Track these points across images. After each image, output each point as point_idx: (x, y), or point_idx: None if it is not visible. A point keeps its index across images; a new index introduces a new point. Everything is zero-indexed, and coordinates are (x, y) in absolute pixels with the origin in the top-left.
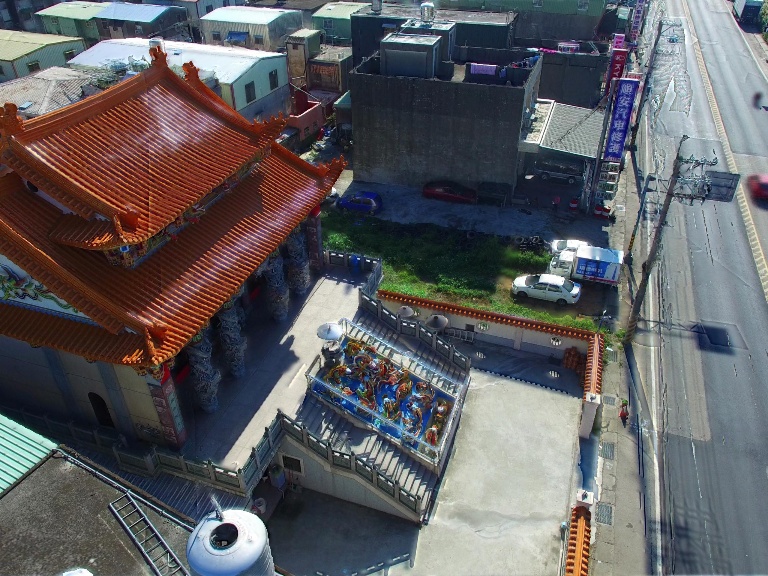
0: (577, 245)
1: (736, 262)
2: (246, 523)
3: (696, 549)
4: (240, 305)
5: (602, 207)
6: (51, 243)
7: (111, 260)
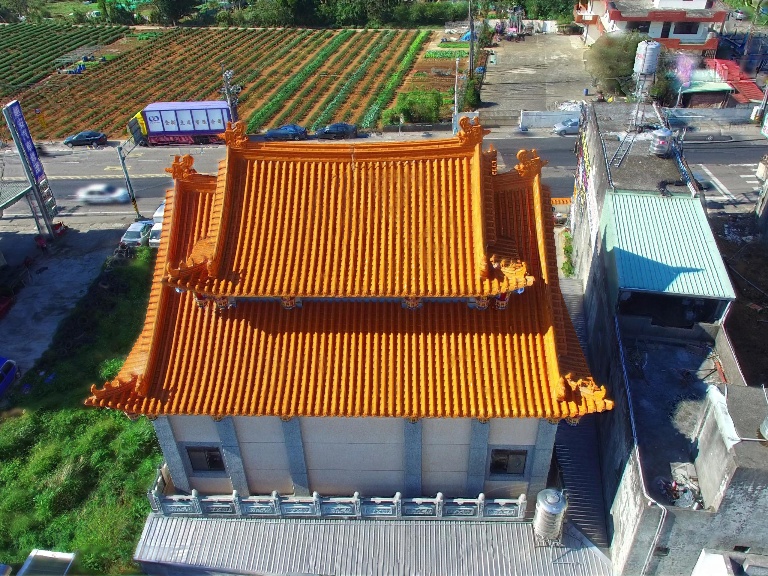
0: (139, 226)
1: (148, 183)
2: None
3: None
4: None
5: (57, 225)
6: None
7: None
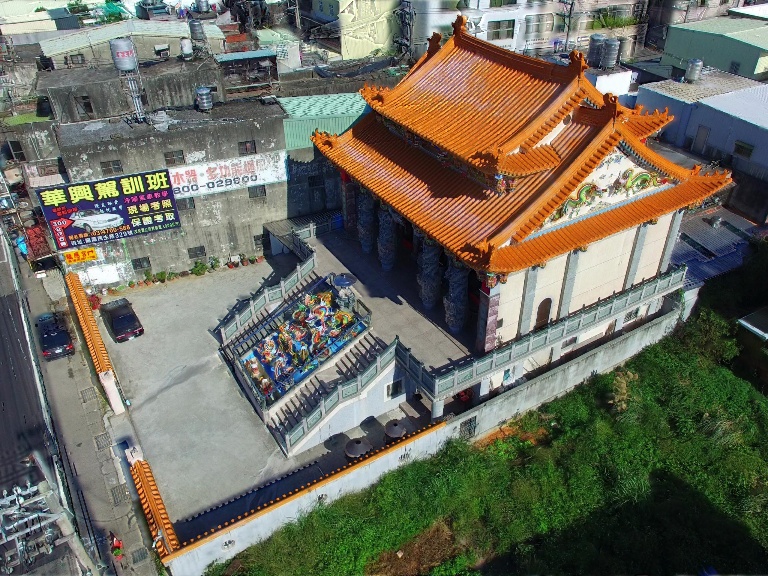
0: None
1: None
2: (118, 40)
3: None
4: None
5: None
6: None
7: None
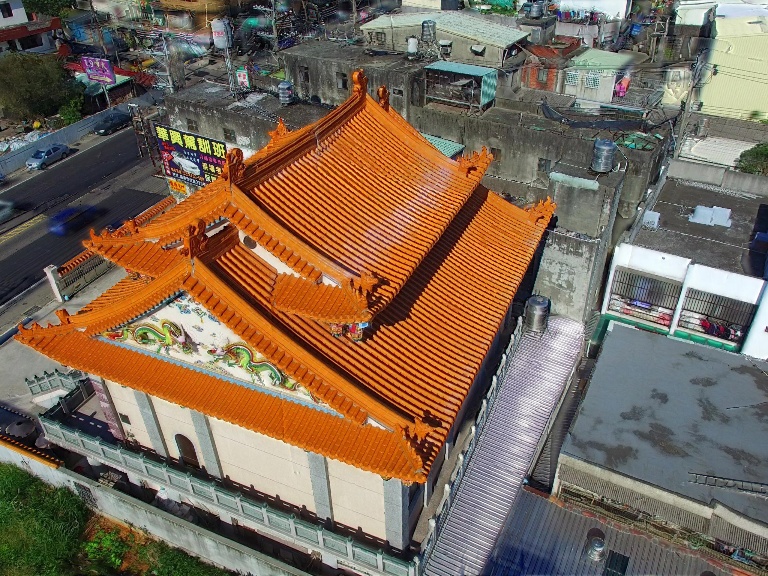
0: None
1: None
2: None
3: (1, 292)
4: None
5: None
6: None
7: None
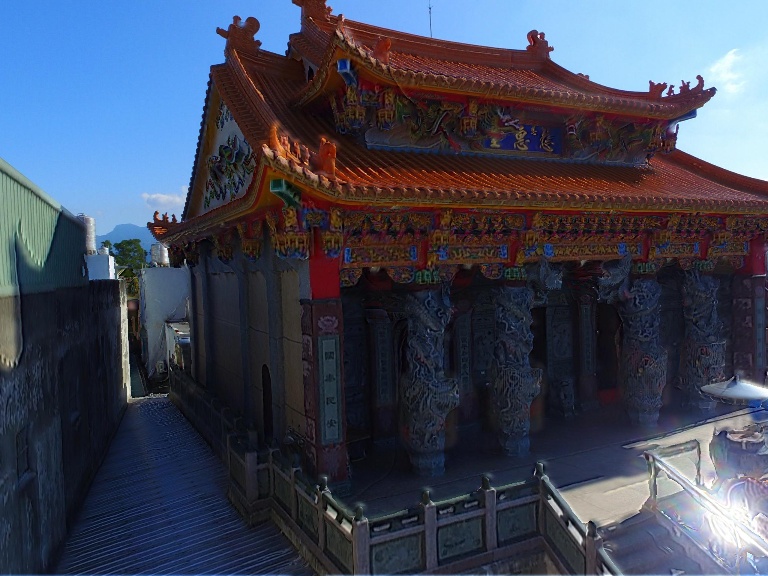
0: None
1: None
2: None
3: None
4: (573, 388)
5: None
6: (286, 108)
7: (338, 121)
